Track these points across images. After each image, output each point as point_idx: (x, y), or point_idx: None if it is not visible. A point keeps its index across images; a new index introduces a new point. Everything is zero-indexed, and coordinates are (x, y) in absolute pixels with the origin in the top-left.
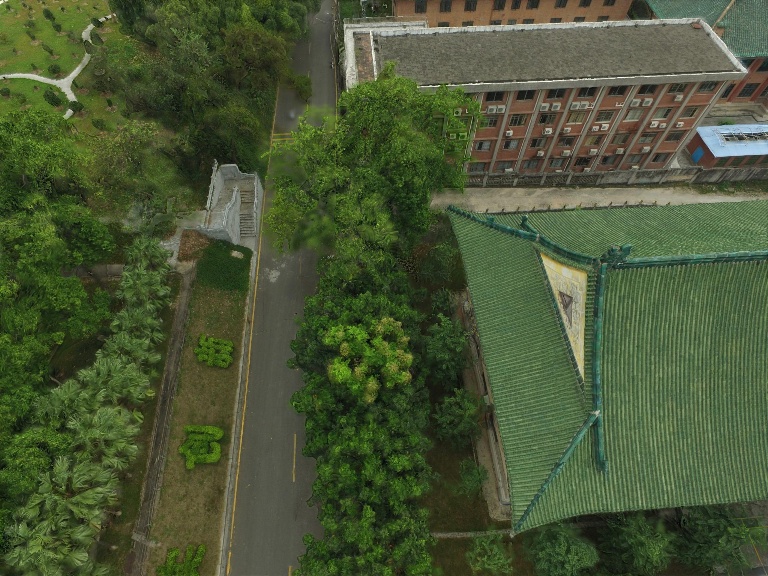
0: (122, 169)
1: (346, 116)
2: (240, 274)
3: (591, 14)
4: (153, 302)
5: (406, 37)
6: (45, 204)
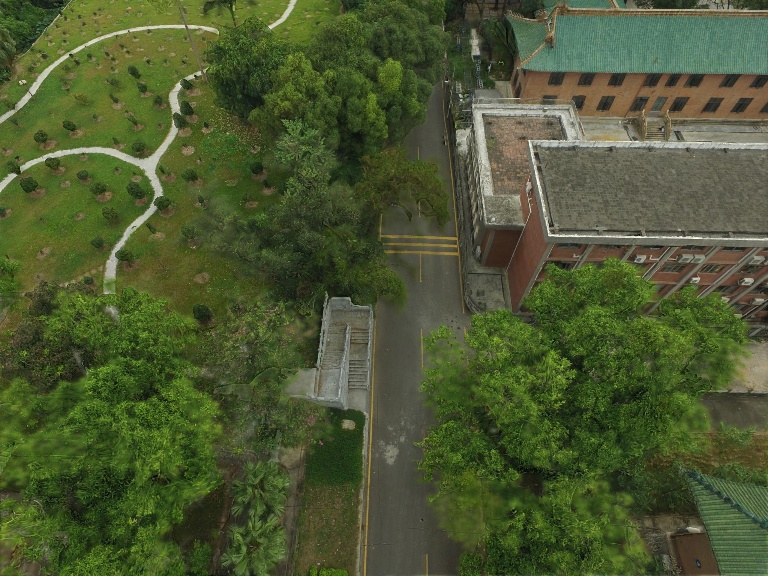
0: (239, 375)
1: (570, 354)
2: (353, 456)
3: (762, 95)
4: (267, 564)
5: (575, 151)
6: (151, 502)
